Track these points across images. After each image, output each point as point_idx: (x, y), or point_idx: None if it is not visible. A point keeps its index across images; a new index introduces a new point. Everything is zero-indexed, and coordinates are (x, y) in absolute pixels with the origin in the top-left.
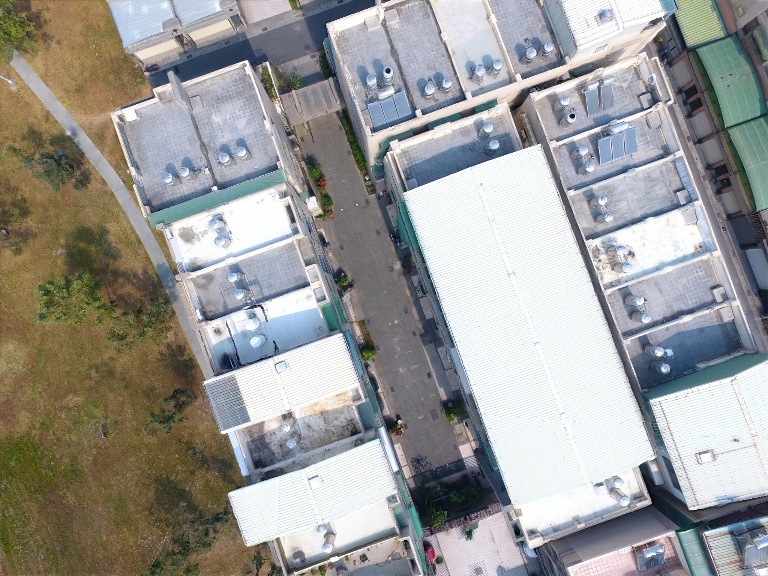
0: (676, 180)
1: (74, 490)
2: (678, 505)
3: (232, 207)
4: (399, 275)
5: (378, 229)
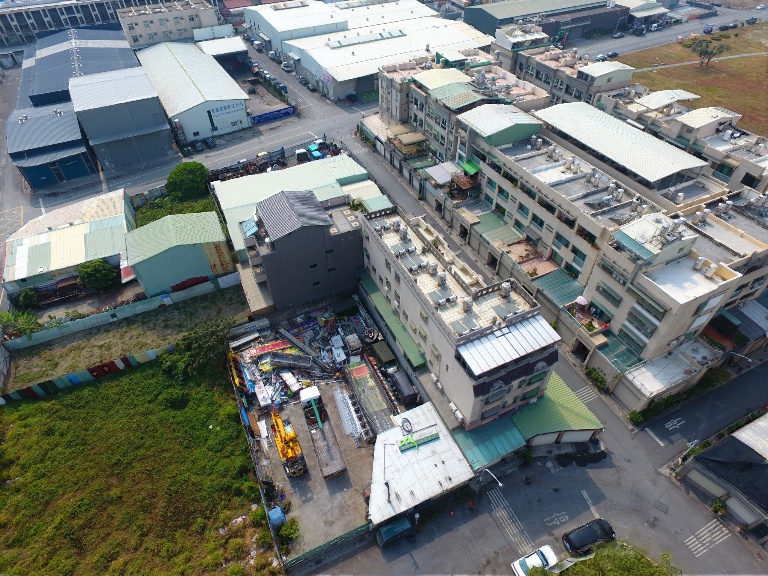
0: None
1: None
2: None
3: None
4: None
5: None
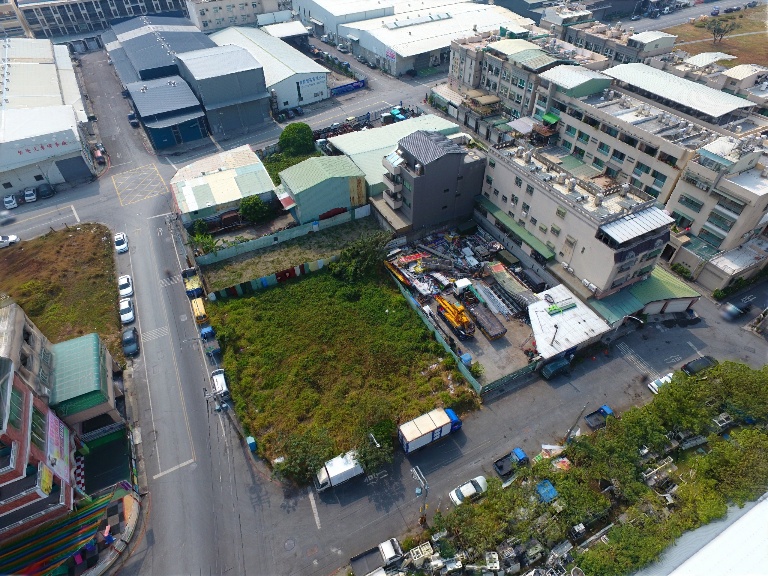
0: None
1: None
2: None
3: None
4: None
5: None
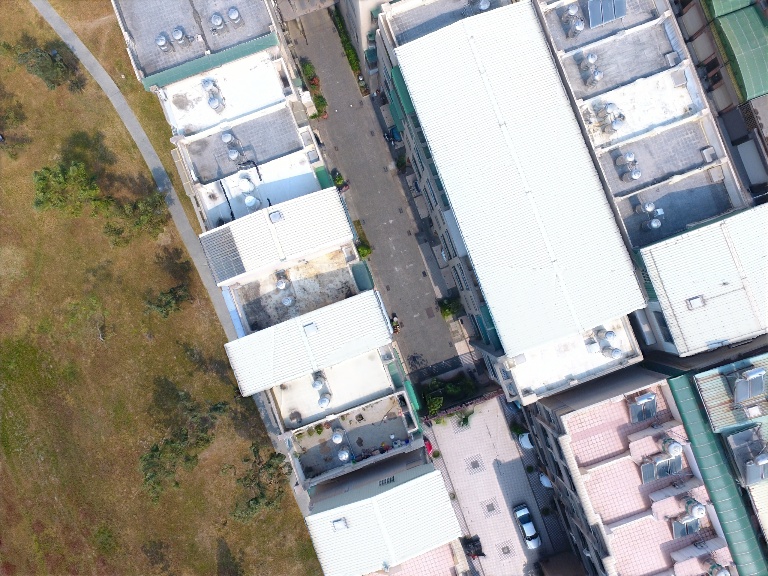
0: (666, 43)
1: (73, 392)
2: (669, 362)
3: (225, 73)
4: (394, 175)
5: (372, 130)
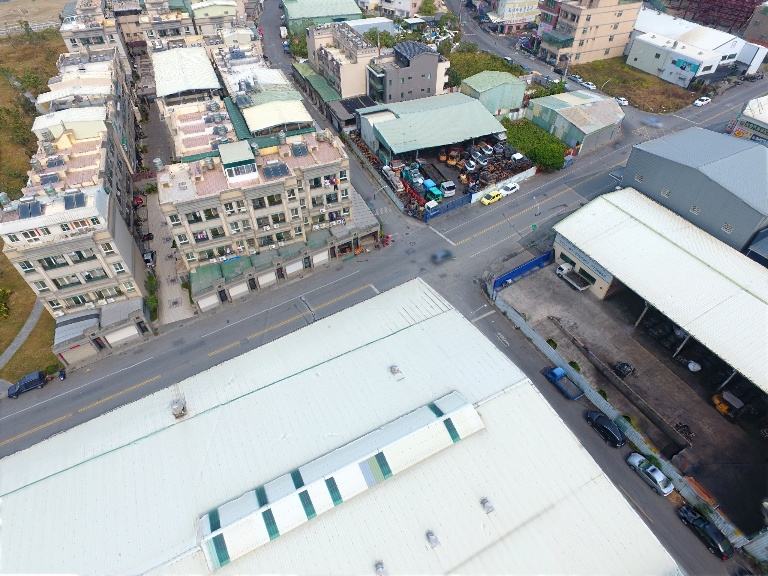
0: None
1: None
2: None
3: (91, 67)
4: None
5: None
